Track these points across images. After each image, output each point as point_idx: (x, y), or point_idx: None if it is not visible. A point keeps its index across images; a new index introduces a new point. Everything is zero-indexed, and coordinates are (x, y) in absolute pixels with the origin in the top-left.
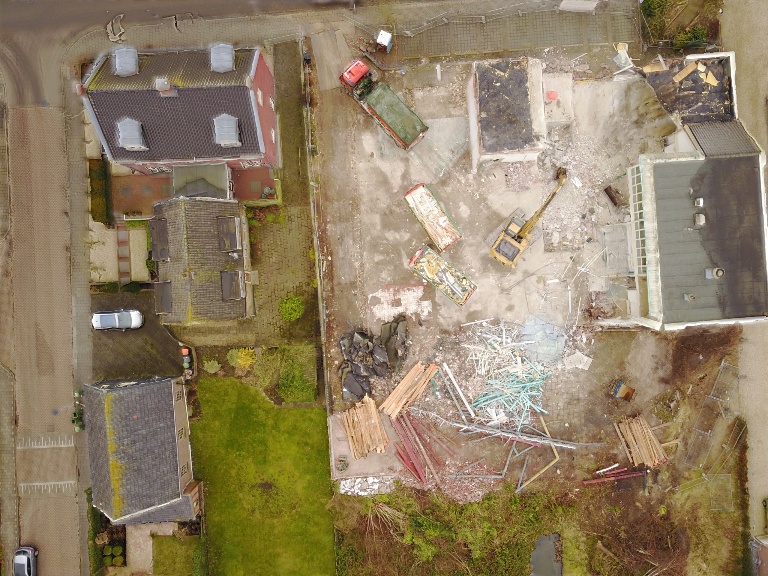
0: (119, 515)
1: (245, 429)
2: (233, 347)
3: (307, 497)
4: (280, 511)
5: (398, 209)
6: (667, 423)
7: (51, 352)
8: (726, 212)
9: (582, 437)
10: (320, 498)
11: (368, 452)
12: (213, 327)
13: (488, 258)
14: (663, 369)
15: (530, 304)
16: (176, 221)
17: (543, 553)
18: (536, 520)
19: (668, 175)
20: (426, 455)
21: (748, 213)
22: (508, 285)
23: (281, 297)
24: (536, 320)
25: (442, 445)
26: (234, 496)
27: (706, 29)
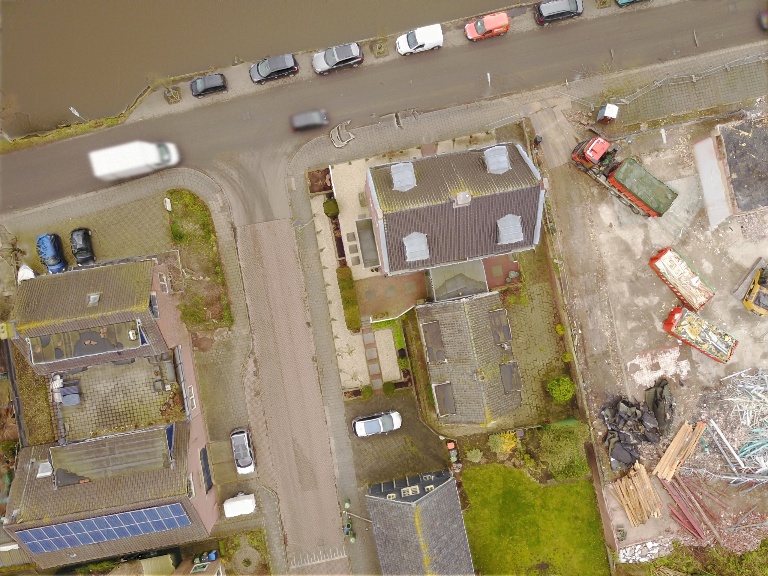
0: None
1: (515, 513)
2: (492, 433)
3: (585, 571)
4: None
5: (643, 275)
6: None
7: (311, 465)
8: None
9: None
10: (598, 570)
11: (648, 518)
12: None
13: (737, 310)
14: None
15: None
16: (455, 323)
17: None
18: None
19: None
20: (703, 512)
21: None
22: (760, 334)
23: (533, 376)
24: None
25: (715, 499)
26: None
27: None
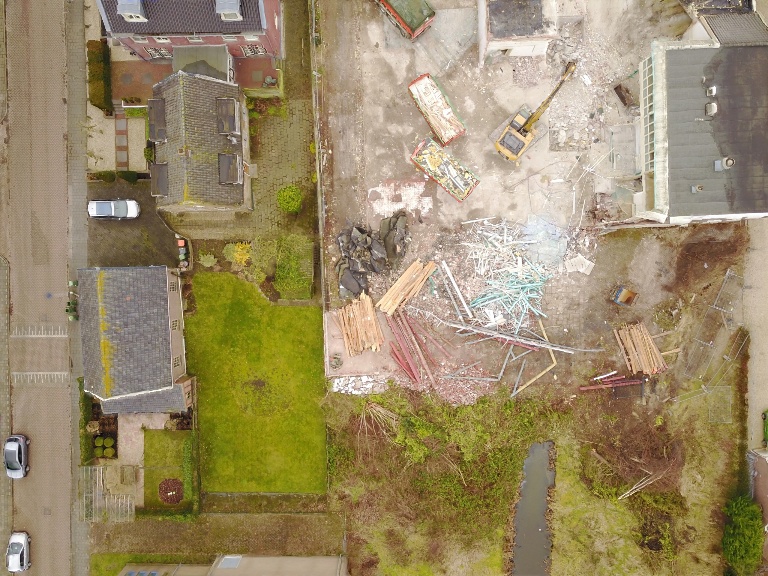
0: (110, 395)
1: (240, 325)
2: (230, 241)
3: (300, 396)
4: (273, 409)
5: (402, 102)
6: (668, 332)
7: (46, 241)
8: (739, 103)
9: (581, 343)
10: (313, 397)
11: (363, 349)
12: (210, 220)
13: (492, 155)
14: (666, 277)
15: (533, 204)
16: (174, 98)
17: (537, 461)
18: (531, 425)
19: (681, 63)
20: (422, 355)
21: (762, 105)
22: (511, 183)
23: None
24: (539, 220)
25: (438, 346)
26: (227, 392)
27: None
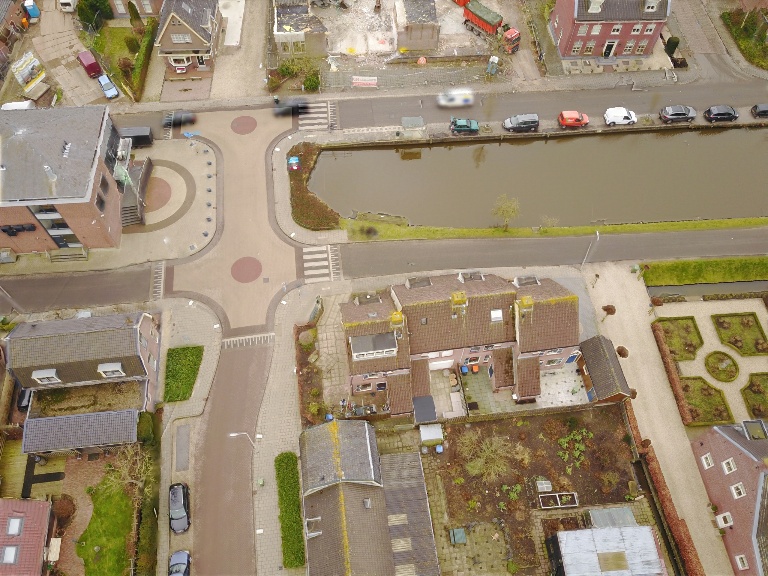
0: None
1: None
2: None
3: None
4: None
5: None
6: None
7: None
8: None
9: None
10: None
11: None
12: None
13: None
14: None
15: None
16: None
17: None
18: None
19: None
20: None
21: None
22: None
23: None
24: None
25: None
26: None
27: (282, 65)
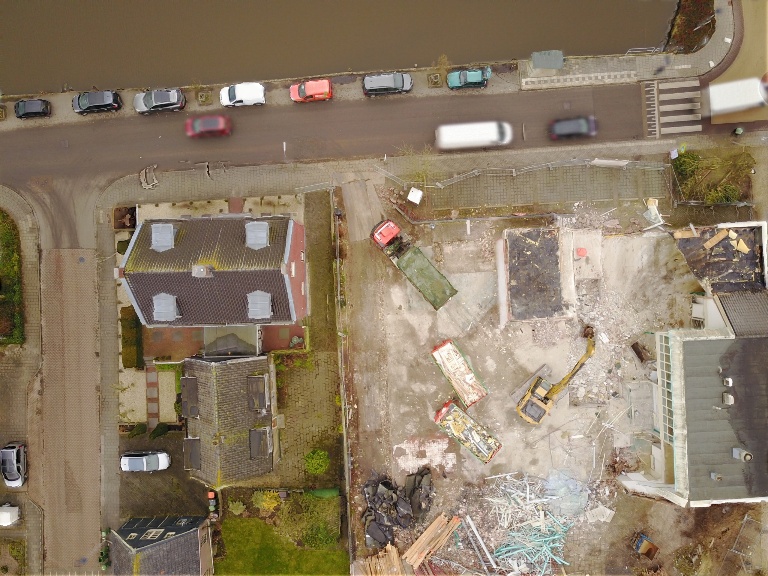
0: None
1: (268, 569)
2: (258, 489)
3: None
4: None
5: (425, 362)
6: None
7: (79, 489)
8: (755, 391)
9: None
10: None
11: None
12: None
13: (513, 412)
14: (685, 523)
15: (554, 459)
16: (207, 383)
17: None
18: None
19: (697, 353)
20: None
21: None
22: (533, 439)
23: (306, 441)
24: (560, 475)
25: None
26: None
27: None
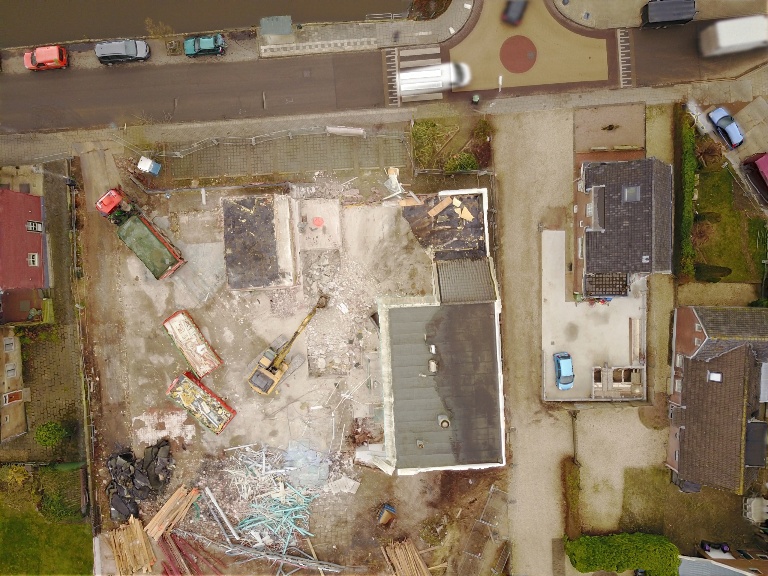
0: None
1: (18, 543)
2: (6, 463)
3: None
4: None
5: (162, 333)
6: (435, 547)
7: None
8: (461, 359)
9: (349, 559)
10: None
11: (133, 572)
12: None
13: None
14: (431, 494)
15: (294, 430)
16: None
17: None
18: None
19: (404, 320)
20: (191, 575)
21: (483, 360)
22: (272, 411)
23: (53, 414)
24: (299, 446)
25: (209, 565)
26: None
27: (471, 158)
